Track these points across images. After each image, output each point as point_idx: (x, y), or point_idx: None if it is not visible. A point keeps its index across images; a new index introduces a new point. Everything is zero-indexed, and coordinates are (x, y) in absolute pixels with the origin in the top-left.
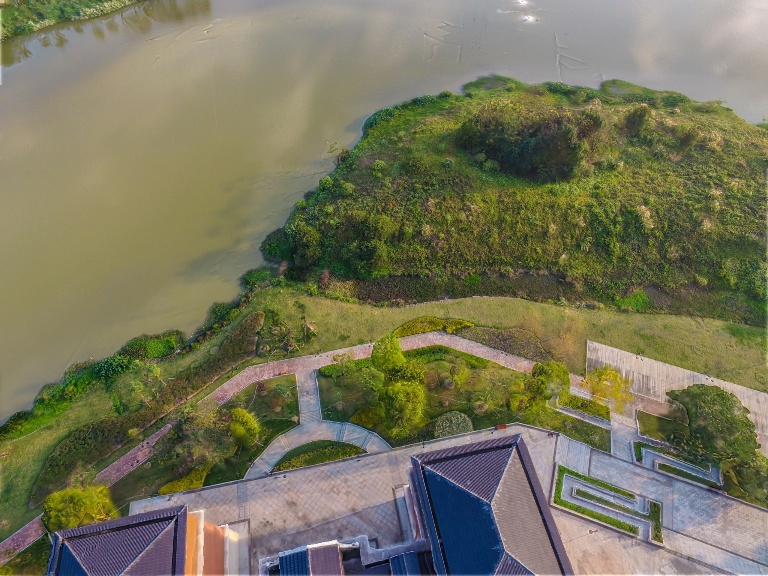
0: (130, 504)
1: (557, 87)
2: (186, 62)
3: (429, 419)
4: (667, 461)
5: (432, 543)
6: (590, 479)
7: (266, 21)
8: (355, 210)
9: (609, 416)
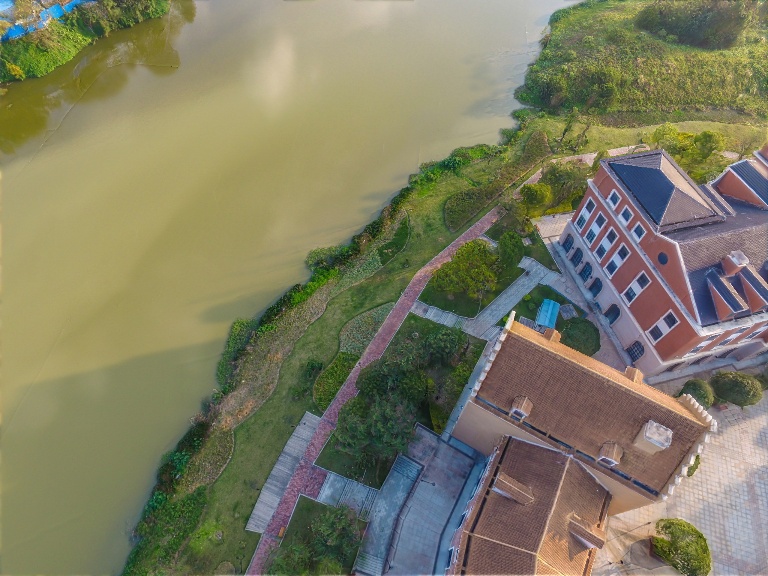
0: (530, 220)
1: None
2: None
3: (700, 175)
4: None
5: None
6: None
7: None
8: None
9: None
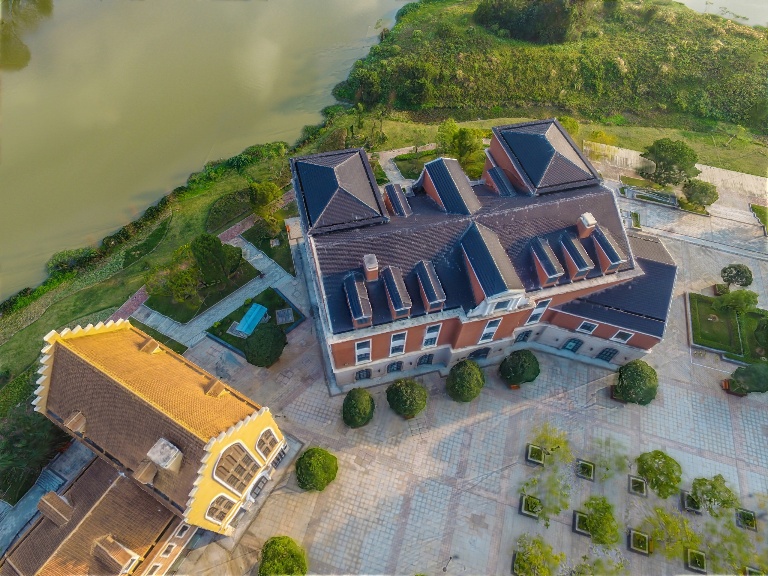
0: (284, 220)
1: None
2: None
3: None
4: None
5: (512, 158)
6: None
7: None
8: None
9: None
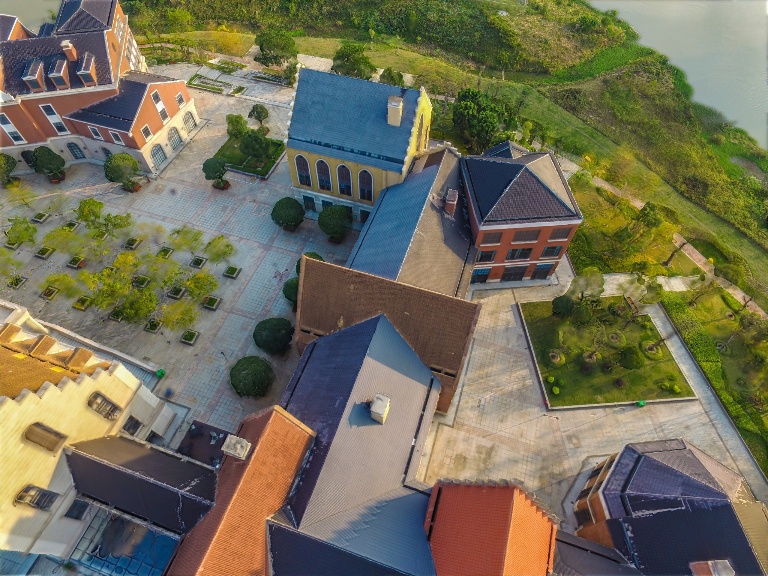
0: None
1: None
2: None
3: None
4: None
5: None
6: (212, 79)
7: None
8: None
9: (243, 67)
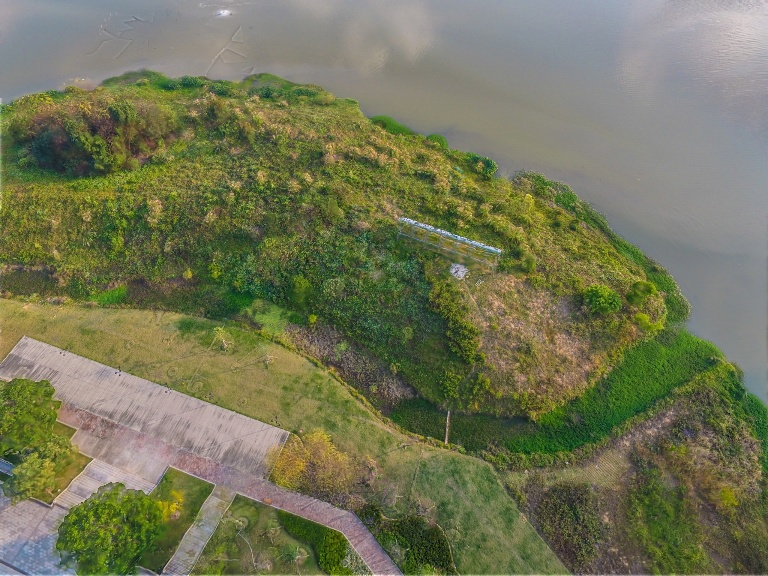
0: None
1: (191, 81)
2: None
3: None
4: None
5: None
6: None
7: None
8: None
9: None
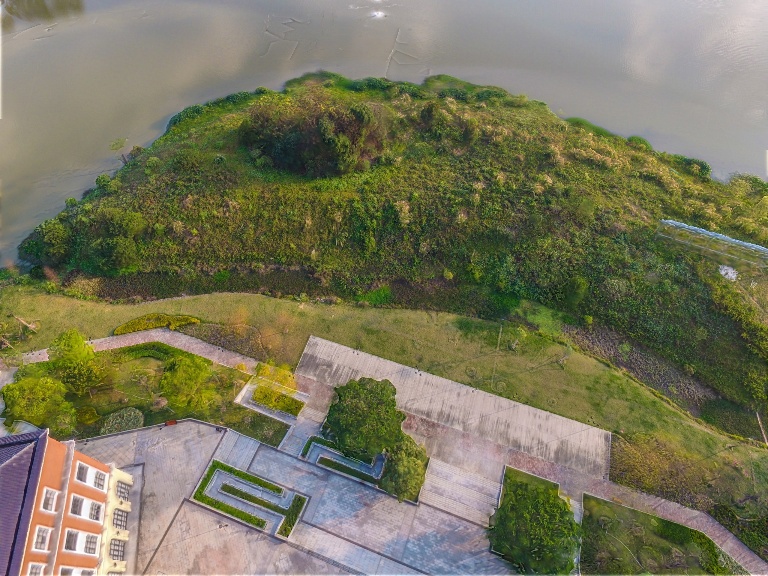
0: None
1: (376, 83)
2: (15, 60)
3: (101, 416)
4: (333, 455)
5: None
6: (243, 474)
7: (112, 19)
8: (109, 207)
9: (298, 411)
